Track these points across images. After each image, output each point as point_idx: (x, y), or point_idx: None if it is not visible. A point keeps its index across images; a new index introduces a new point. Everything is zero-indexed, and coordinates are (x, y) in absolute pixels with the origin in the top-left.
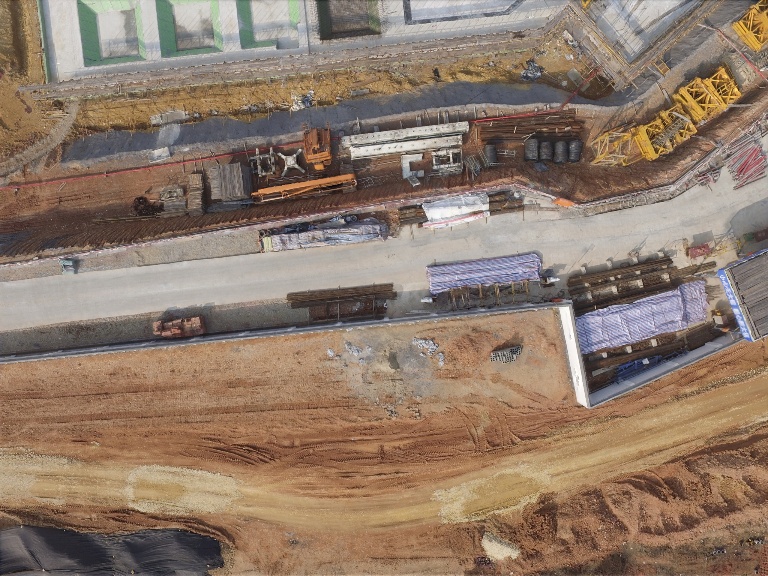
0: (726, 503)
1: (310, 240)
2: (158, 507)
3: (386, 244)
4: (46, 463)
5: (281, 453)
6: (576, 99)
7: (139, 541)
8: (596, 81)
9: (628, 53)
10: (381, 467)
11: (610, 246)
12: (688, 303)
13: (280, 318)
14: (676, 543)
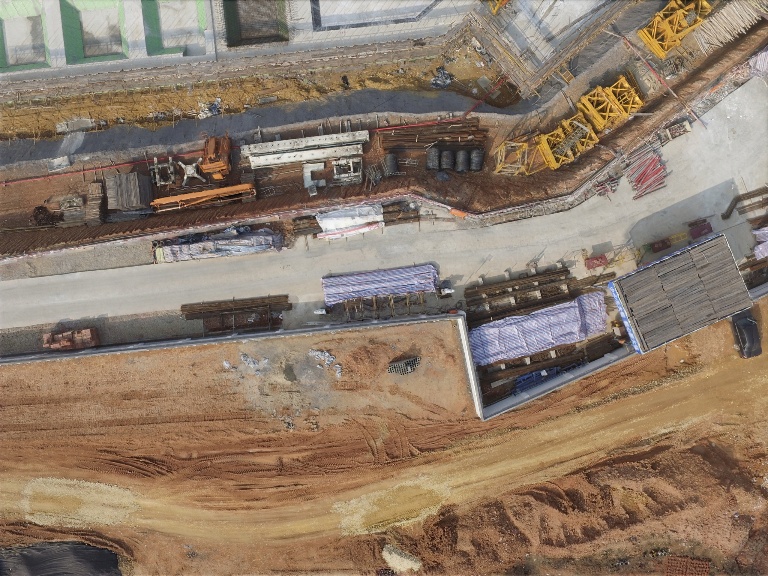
0: (628, 515)
1: (201, 251)
2: (55, 520)
3: (281, 255)
4: None
5: (179, 465)
6: (482, 107)
7: (36, 554)
8: (506, 88)
9: (539, 60)
10: (280, 479)
11: (508, 257)
12: (587, 314)
13: (174, 330)
14: (579, 555)
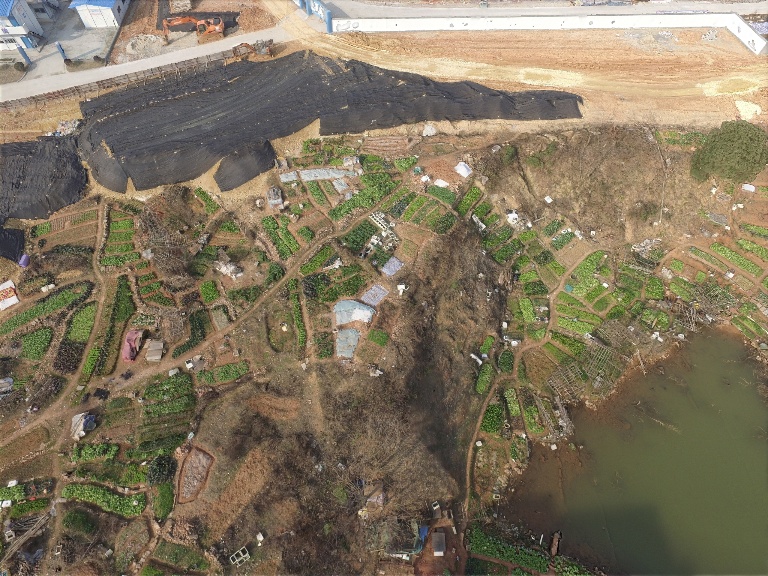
0: None
1: None
2: (539, 82)
3: (632, 6)
4: (474, 64)
5: None
6: None
7: (531, 93)
8: None
9: None
10: (661, 73)
11: None
12: None
13: (589, 23)
14: None
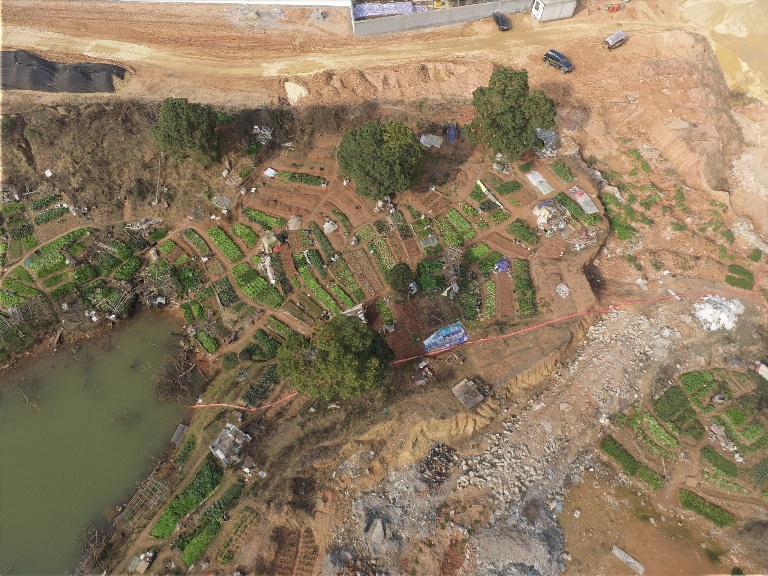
0: None
1: None
2: (100, 55)
3: None
4: (50, 34)
5: (182, 42)
6: None
7: (80, 65)
8: None
9: None
10: (236, 51)
11: None
12: (418, 10)
13: None
14: (408, 100)
